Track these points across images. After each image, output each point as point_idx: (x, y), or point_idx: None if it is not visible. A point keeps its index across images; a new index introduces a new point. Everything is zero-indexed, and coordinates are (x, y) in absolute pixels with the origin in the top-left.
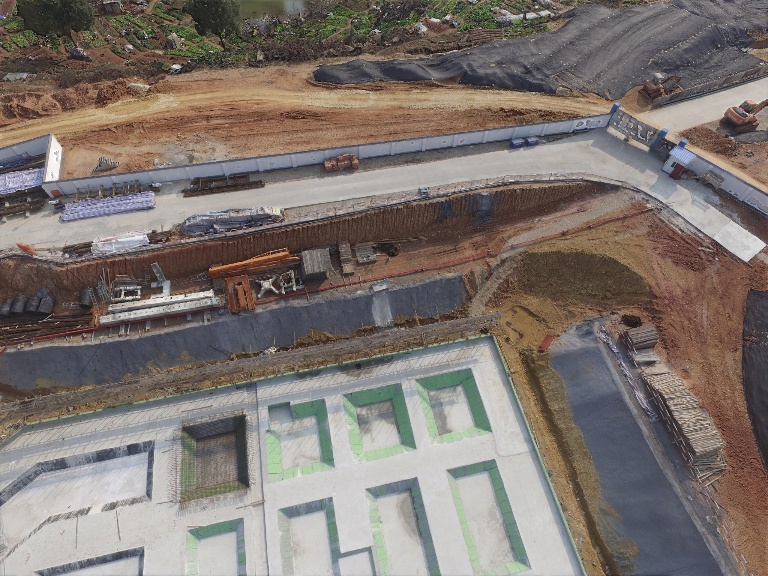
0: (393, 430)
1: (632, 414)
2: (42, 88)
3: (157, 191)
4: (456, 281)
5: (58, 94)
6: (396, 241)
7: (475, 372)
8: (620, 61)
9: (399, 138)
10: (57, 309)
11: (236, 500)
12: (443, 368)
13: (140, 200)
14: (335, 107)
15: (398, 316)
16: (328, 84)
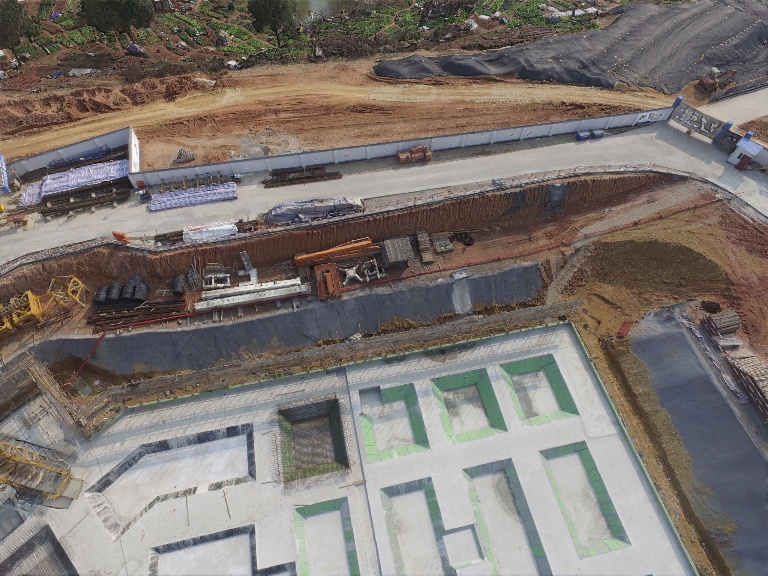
0: (481, 413)
1: (722, 396)
2: (109, 83)
3: (238, 182)
4: (532, 269)
5: (127, 89)
6: (471, 231)
7: (557, 357)
8: (673, 56)
9: (466, 131)
10: (150, 296)
11: (338, 480)
12: (525, 354)
13: (224, 191)
14: (399, 101)
15: (477, 304)
16: (389, 79)
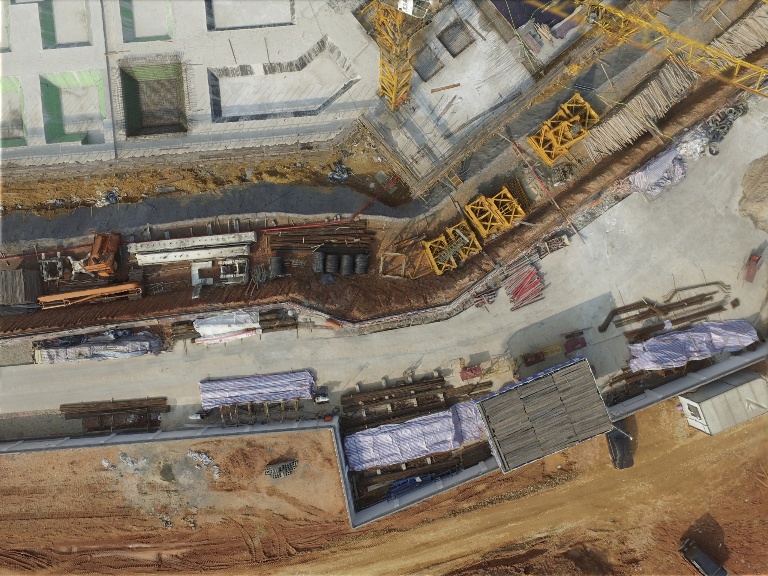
0: None
1: None
2: None
3: None
4: None
5: None
6: None
7: None
8: None
9: None
10: None
11: None
12: None
13: (216, 394)
14: None
15: None
16: None
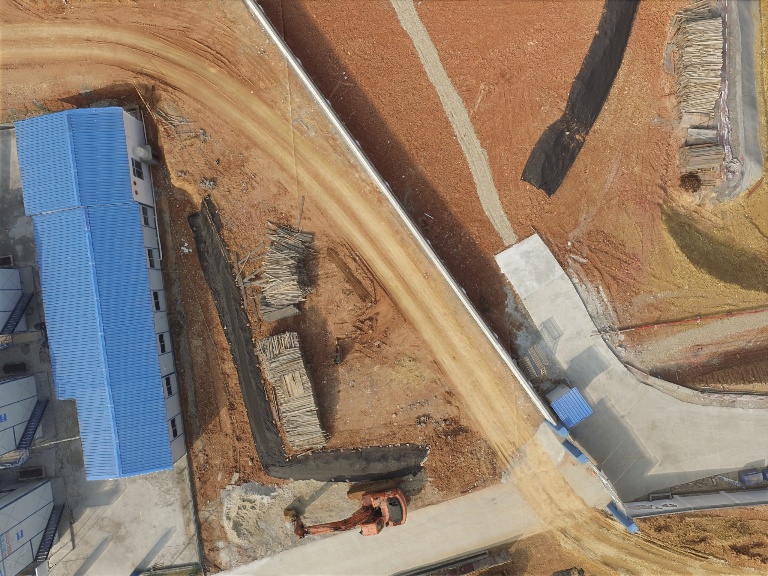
0: None
1: None
2: None
3: None
4: None
5: None
6: None
7: None
8: None
9: None
10: None
11: None
12: None
13: None
14: None
15: None
16: None
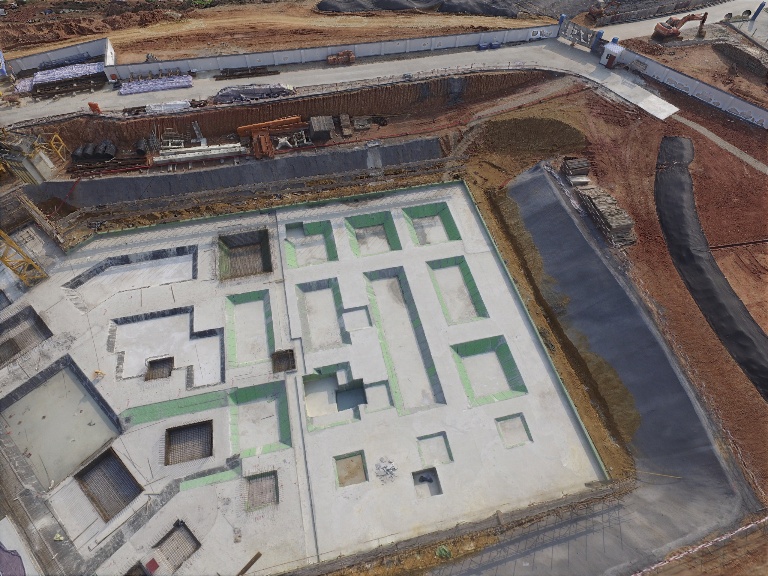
0: (384, 242)
1: (567, 212)
2: (93, 17)
3: (194, 76)
4: (434, 142)
5: (107, 19)
6: (386, 116)
7: (449, 204)
8: None
9: None
10: (118, 156)
11: (263, 279)
12: (424, 201)
13: (181, 80)
14: (335, 27)
15: None
16: (329, 12)
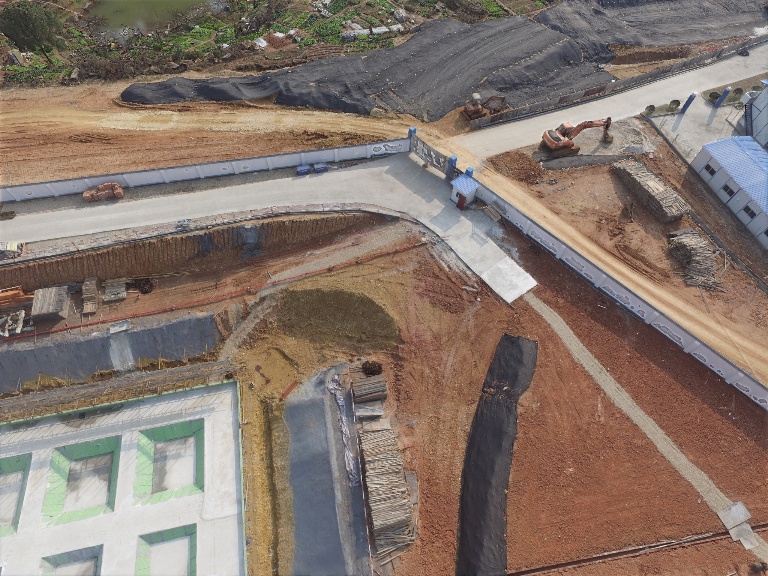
0: (103, 487)
1: (332, 477)
2: None
3: None
4: (207, 321)
5: None
6: (153, 276)
7: (207, 422)
8: (452, 79)
9: (183, 164)
10: None
11: None
12: (174, 418)
13: None
14: (131, 129)
15: (139, 359)
16: (133, 104)
